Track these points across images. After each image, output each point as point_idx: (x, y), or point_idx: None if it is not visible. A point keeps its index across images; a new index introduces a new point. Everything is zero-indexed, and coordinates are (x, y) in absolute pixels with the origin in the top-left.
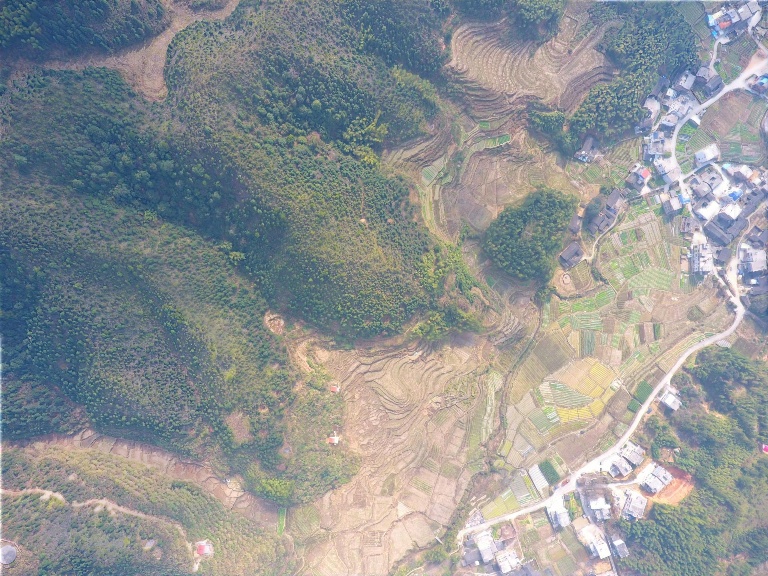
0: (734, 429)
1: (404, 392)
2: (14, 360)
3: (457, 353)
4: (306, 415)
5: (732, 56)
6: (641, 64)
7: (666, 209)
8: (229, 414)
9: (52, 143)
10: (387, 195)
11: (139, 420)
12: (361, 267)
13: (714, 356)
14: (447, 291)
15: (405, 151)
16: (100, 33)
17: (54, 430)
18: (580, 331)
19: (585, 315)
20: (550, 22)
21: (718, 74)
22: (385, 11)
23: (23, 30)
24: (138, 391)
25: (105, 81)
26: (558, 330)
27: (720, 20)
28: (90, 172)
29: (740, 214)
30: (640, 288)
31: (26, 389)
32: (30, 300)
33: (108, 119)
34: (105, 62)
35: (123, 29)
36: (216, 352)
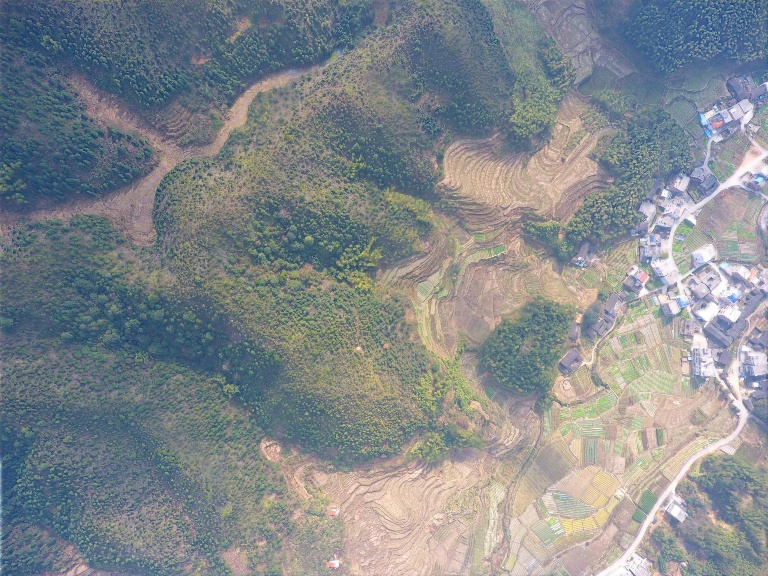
0: (742, 543)
1: (405, 512)
2: (4, 507)
3: (458, 468)
4: (305, 542)
5: (726, 154)
6: (635, 173)
7: (665, 311)
8: (226, 550)
9: (39, 302)
10: (383, 319)
11: (134, 560)
12: (358, 398)
13: (719, 465)
14: (446, 409)
15: (400, 269)
16: (87, 181)
17: (46, 569)
18: (582, 439)
19: (586, 422)
20: (543, 133)
21: (712, 173)
22: (376, 141)
23: (8, 188)
24: (132, 534)
25: (93, 231)
26: (560, 438)
27: (713, 120)
28: (79, 323)
29: (740, 316)
30: (641, 393)
31: (17, 532)
32: (19, 453)
33: (96, 272)
34: (93, 207)
35: (110, 175)
36: (211, 492)
